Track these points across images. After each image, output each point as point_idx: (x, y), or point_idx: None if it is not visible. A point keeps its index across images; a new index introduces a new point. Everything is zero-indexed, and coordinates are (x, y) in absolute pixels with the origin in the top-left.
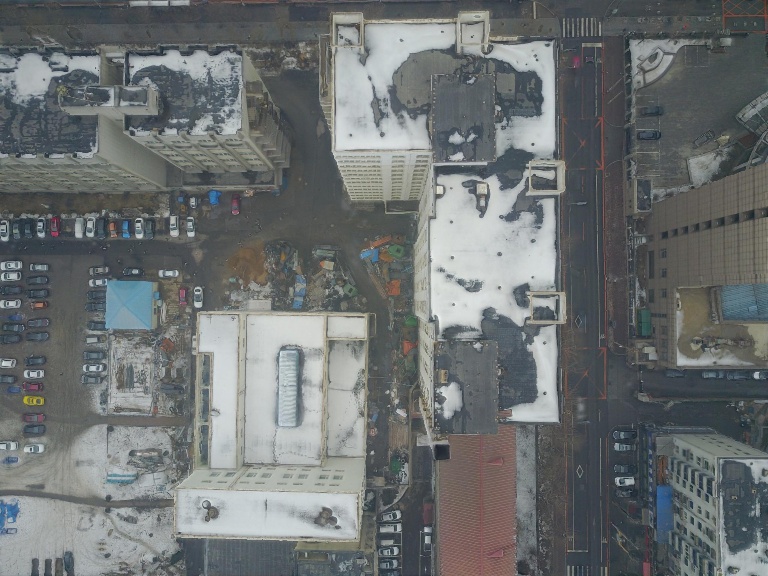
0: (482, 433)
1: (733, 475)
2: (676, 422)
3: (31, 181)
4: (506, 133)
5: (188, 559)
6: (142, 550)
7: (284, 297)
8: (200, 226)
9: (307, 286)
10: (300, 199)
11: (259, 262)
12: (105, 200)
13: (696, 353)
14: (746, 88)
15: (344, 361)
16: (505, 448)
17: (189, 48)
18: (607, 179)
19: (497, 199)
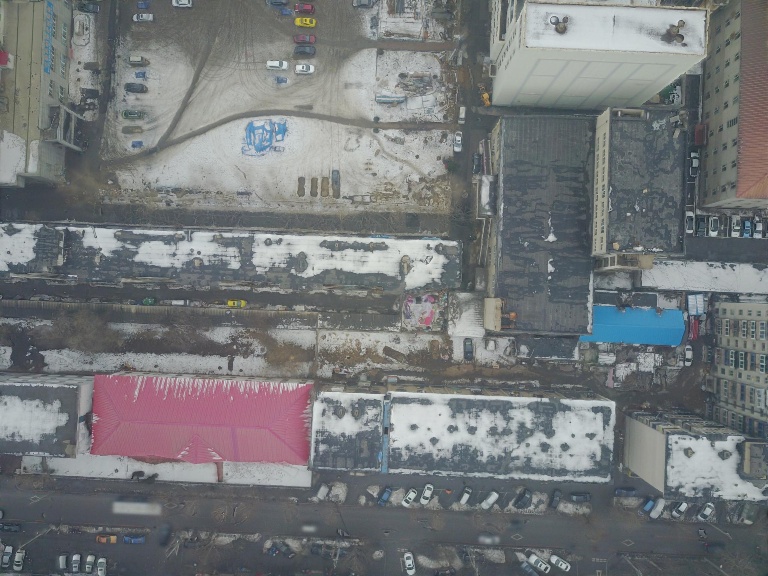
0: None
1: None
2: None
3: None
4: None
5: (453, 181)
6: (408, 171)
7: None
8: None
9: None
10: None
11: None
12: None
13: None
14: None
15: None
16: None
17: None
18: None
19: None
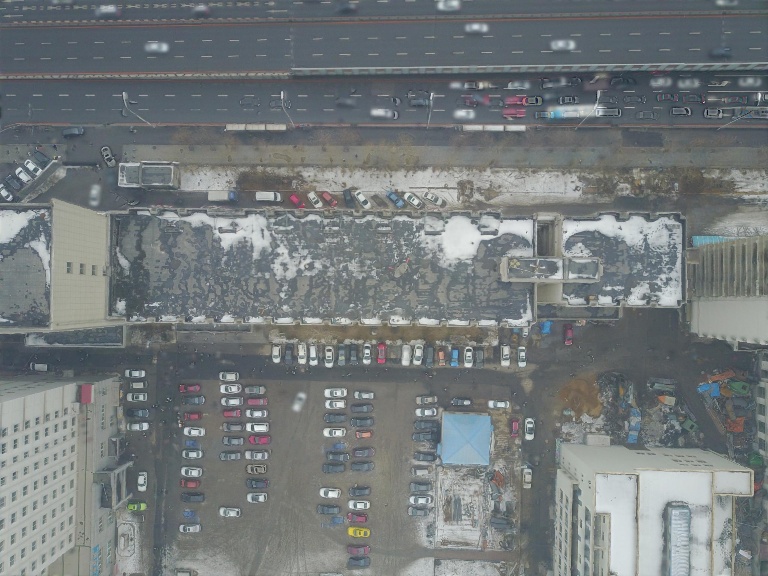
0: None
1: None
2: None
3: None
4: None
5: None
6: None
7: (619, 431)
8: (530, 355)
9: (642, 420)
10: (634, 330)
11: (592, 394)
12: None
13: None
14: None
15: None
16: None
17: (628, 215)
18: None
19: None
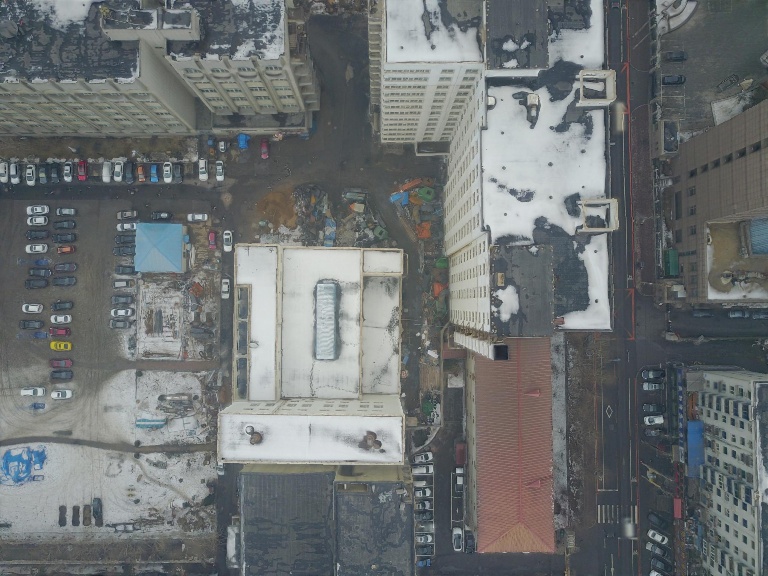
0: None
1: None
2: (703, 361)
3: (61, 120)
4: (555, 46)
5: (218, 504)
6: (172, 495)
7: (314, 240)
8: (229, 170)
9: (337, 229)
10: (329, 143)
11: (289, 206)
12: (133, 144)
13: (726, 287)
14: (767, 34)
15: (378, 299)
16: (541, 380)
17: None
18: (633, 123)
19: (547, 110)
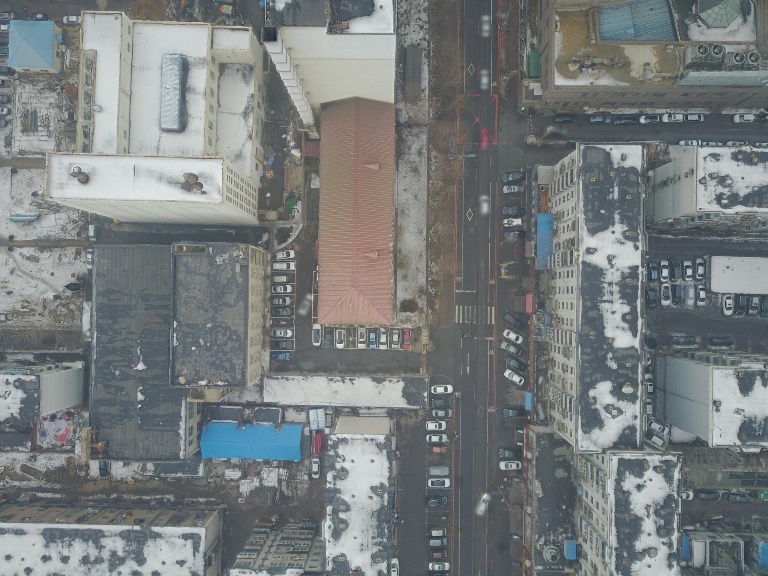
0: (312, 25)
1: (593, 160)
2: None
3: None
4: None
5: (88, 297)
6: (43, 288)
7: None
8: None
9: None
10: None
11: (161, 10)
12: None
13: (573, 73)
14: None
15: (234, 85)
16: (382, 155)
17: None
18: None
19: None
